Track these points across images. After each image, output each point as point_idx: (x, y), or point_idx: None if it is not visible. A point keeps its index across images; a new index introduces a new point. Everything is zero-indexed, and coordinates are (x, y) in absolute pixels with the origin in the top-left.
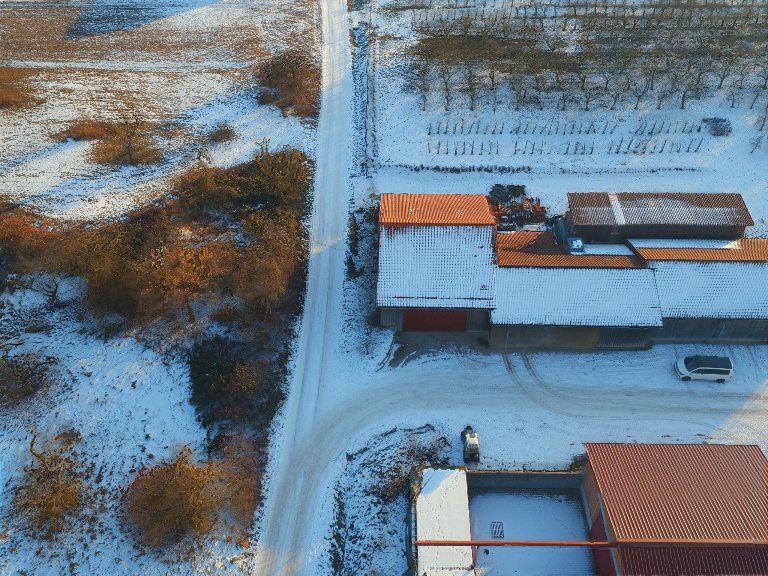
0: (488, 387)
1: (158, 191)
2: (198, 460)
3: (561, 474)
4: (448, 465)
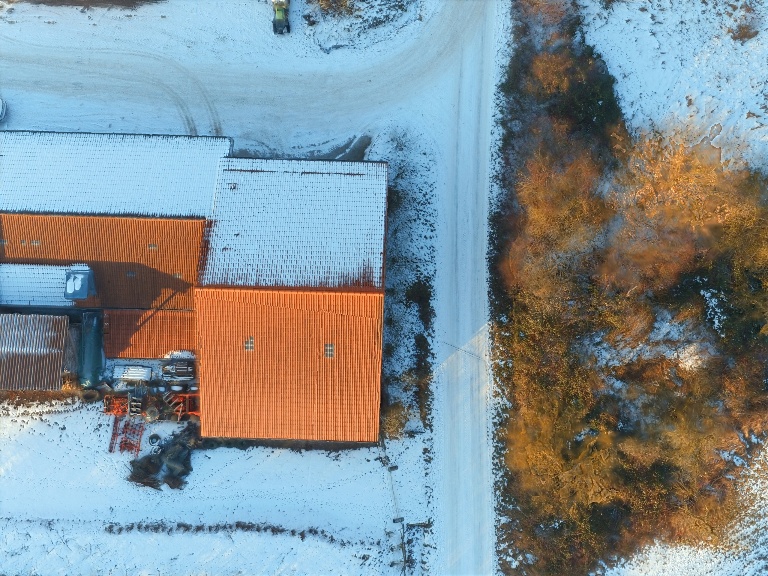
0: (249, 102)
1: (762, 476)
2: (588, 7)
3: None
4: None
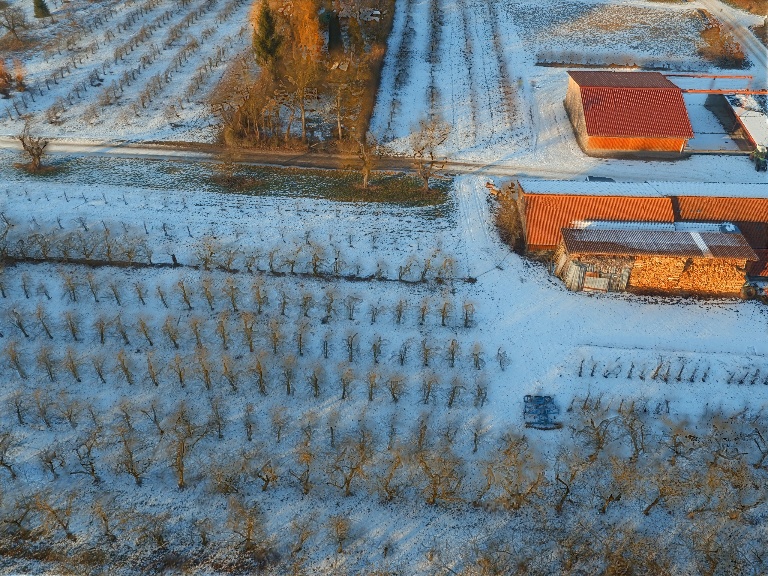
0: None
1: None
2: None
3: (698, 150)
4: (767, 159)
